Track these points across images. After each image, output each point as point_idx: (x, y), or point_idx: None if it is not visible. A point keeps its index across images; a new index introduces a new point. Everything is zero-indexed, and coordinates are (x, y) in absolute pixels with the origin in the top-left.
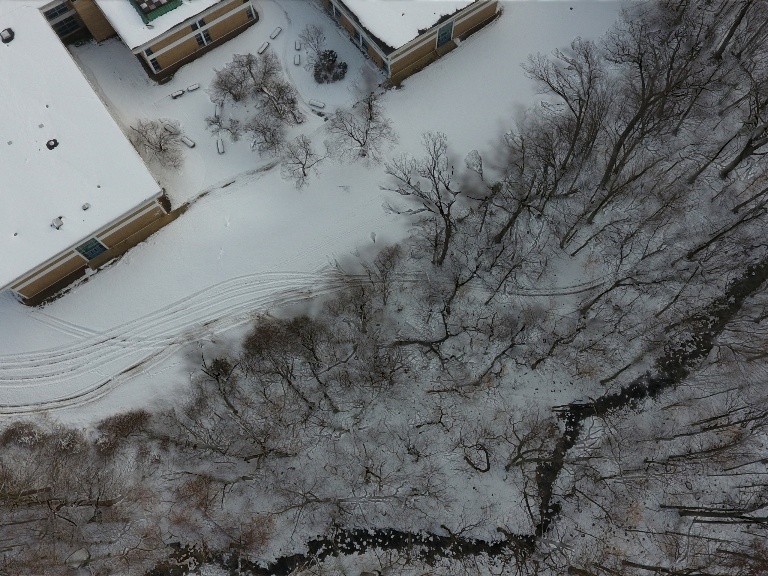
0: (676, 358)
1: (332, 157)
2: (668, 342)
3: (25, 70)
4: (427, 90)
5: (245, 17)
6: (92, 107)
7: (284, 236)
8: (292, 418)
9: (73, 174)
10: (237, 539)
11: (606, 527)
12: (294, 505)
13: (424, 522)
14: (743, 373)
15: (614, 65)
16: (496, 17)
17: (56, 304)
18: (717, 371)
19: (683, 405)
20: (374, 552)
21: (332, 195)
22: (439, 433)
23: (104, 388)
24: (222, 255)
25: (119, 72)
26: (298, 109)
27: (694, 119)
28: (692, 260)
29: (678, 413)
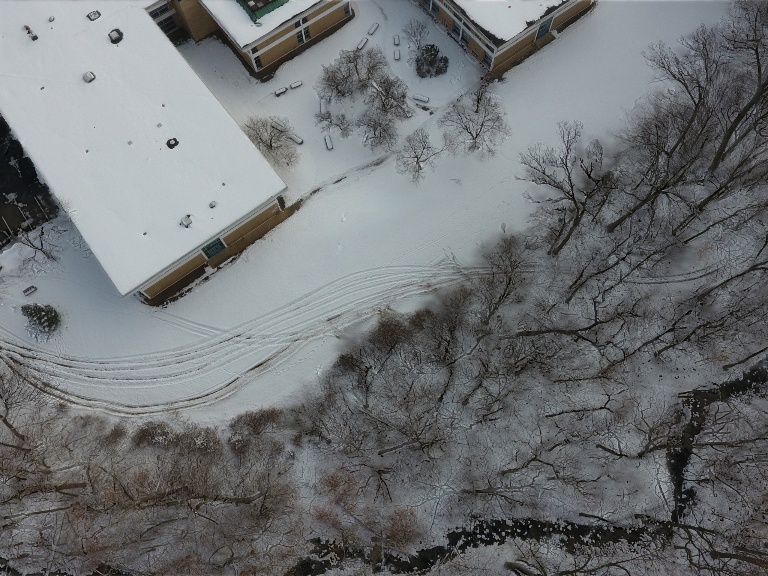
0: None
1: (451, 150)
2: None
3: (137, 70)
4: (529, 82)
5: (342, 13)
6: (208, 105)
7: (400, 230)
8: None
9: (196, 172)
10: (378, 533)
11: (743, 511)
12: (431, 497)
13: (562, 511)
14: None
15: (726, 52)
16: (591, 8)
17: (179, 303)
18: None
19: None
20: (513, 542)
21: (445, 188)
22: (573, 422)
23: (233, 386)
24: (340, 250)
25: (220, 71)
26: (407, 103)
27: None
28: None
29: None
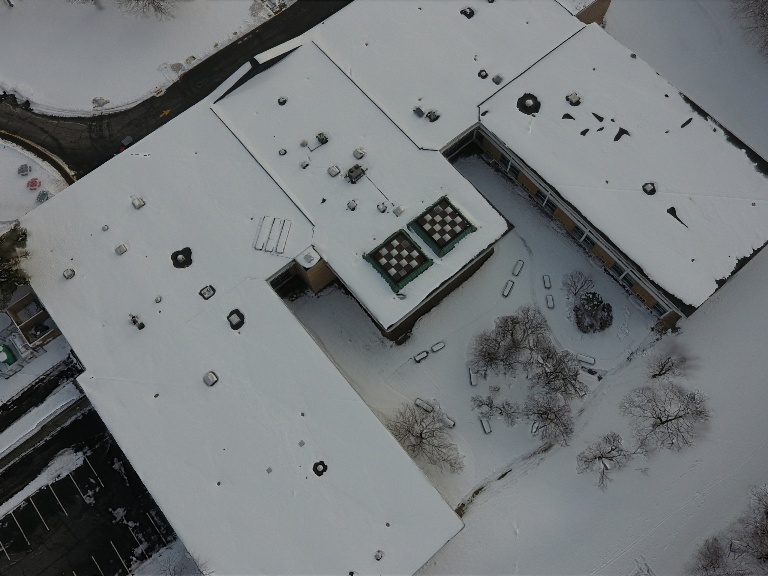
0: None
1: (648, 455)
2: None
3: (267, 366)
4: (708, 332)
5: None
6: (356, 412)
7: (584, 541)
8: None
9: (353, 509)
10: None
11: None
12: None
13: None
14: None
15: None
16: None
17: None
18: None
19: None
20: None
21: (629, 481)
22: None
23: None
24: (518, 574)
25: (347, 331)
26: (577, 378)
27: None
28: None
29: None
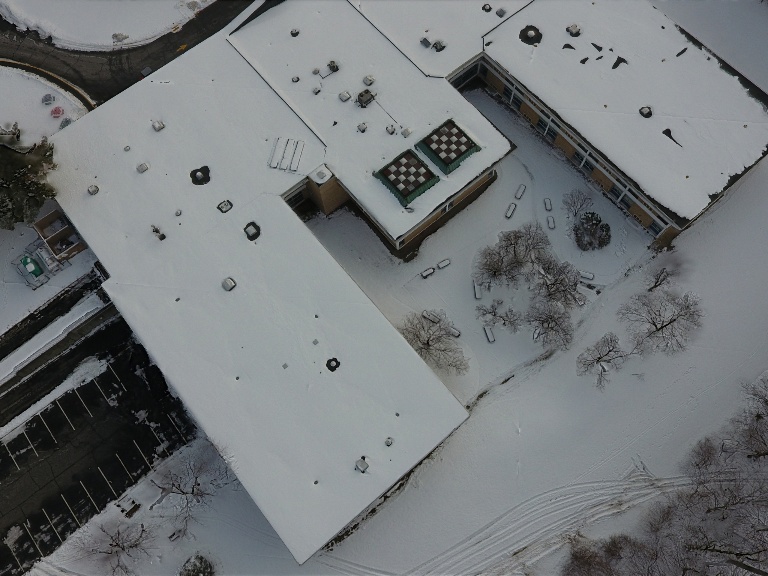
0: None
1: (643, 355)
2: None
3: (282, 273)
4: (702, 250)
5: (486, 177)
6: (367, 314)
7: (583, 440)
8: None
9: (365, 401)
10: None
11: None
12: None
13: None
14: None
15: None
16: None
17: (346, 544)
18: None
19: None
20: None
21: (626, 385)
22: None
23: None
24: (520, 469)
25: (357, 250)
26: None
27: None
28: None
29: None
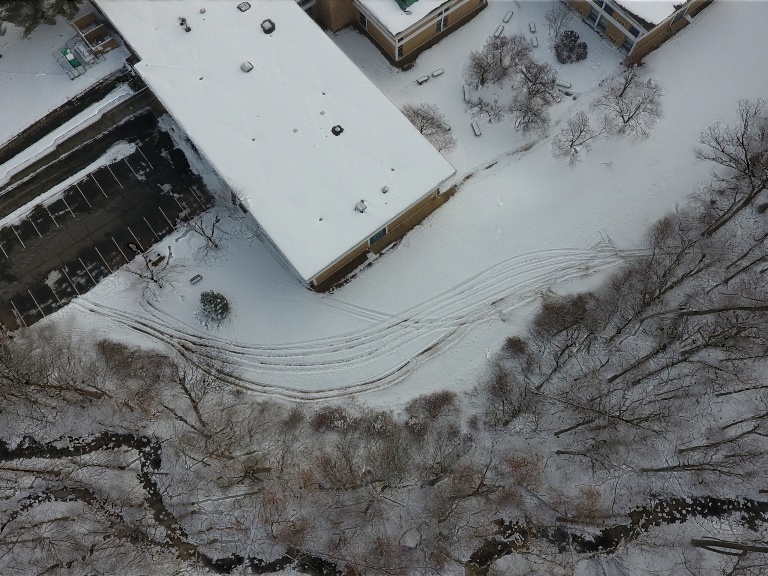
0: None
1: (610, 132)
2: None
3: (294, 59)
4: (669, 66)
5: (478, 2)
6: (369, 93)
7: (556, 214)
8: None
9: (365, 158)
10: (563, 513)
11: None
12: (610, 477)
13: (741, 488)
14: None
15: None
16: None
17: (345, 289)
18: None
19: None
20: (695, 520)
21: (596, 172)
22: None
23: (404, 370)
24: (500, 235)
25: (360, 61)
26: None
27: None
28: None
29: None
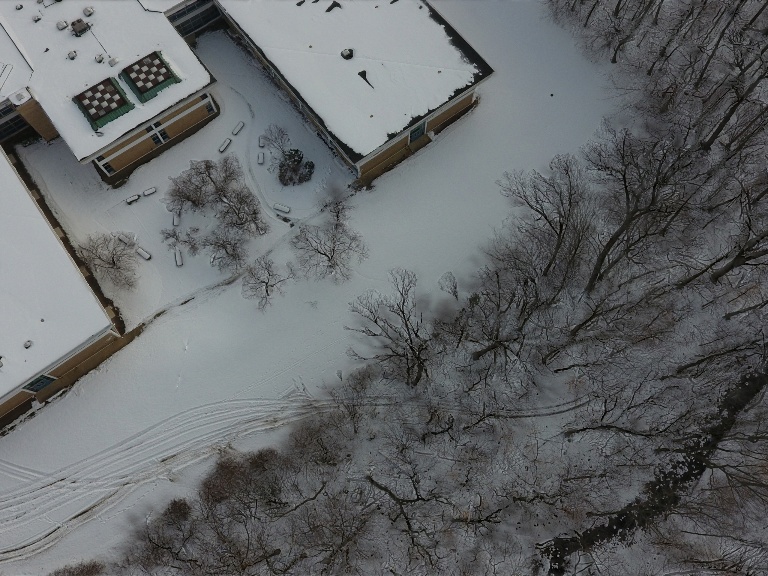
0: (666, 482)
1: (296, 279)
2: (658, 465)
3: None
4: (399, 191)
5: (205, 112)
6: (36, 228)
7: (247, 359)
8: (256, 567)
9: (14, 306)
10: None
11: None
12: None
13: None
14: (737, 502)
15: (596, 173)
16: (472, 107)
17: None
18: (710, 498)
19: (674, 546)
20: None
21: (298, 312)
22: None
23: (52, 537)
24: (180, 383)
25: (70, 175)
26: (261, 218)
27: (682, 222)
28: (682, 376)
29: (669, 548)
